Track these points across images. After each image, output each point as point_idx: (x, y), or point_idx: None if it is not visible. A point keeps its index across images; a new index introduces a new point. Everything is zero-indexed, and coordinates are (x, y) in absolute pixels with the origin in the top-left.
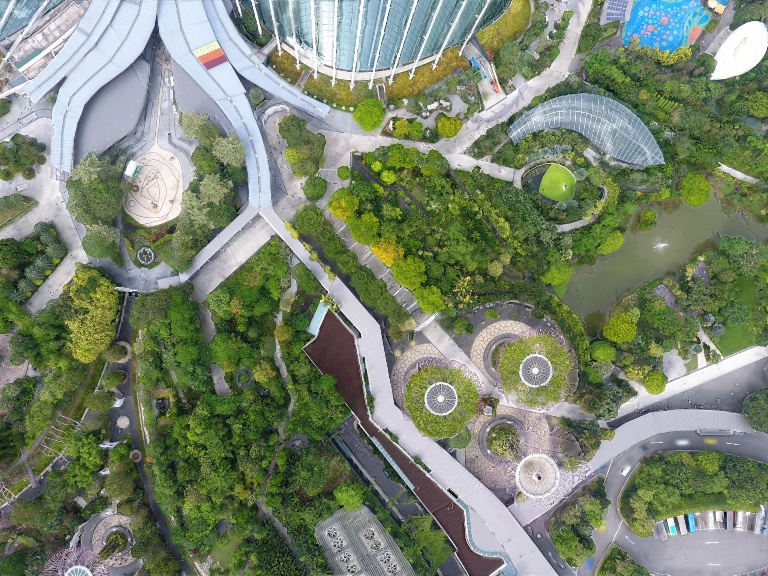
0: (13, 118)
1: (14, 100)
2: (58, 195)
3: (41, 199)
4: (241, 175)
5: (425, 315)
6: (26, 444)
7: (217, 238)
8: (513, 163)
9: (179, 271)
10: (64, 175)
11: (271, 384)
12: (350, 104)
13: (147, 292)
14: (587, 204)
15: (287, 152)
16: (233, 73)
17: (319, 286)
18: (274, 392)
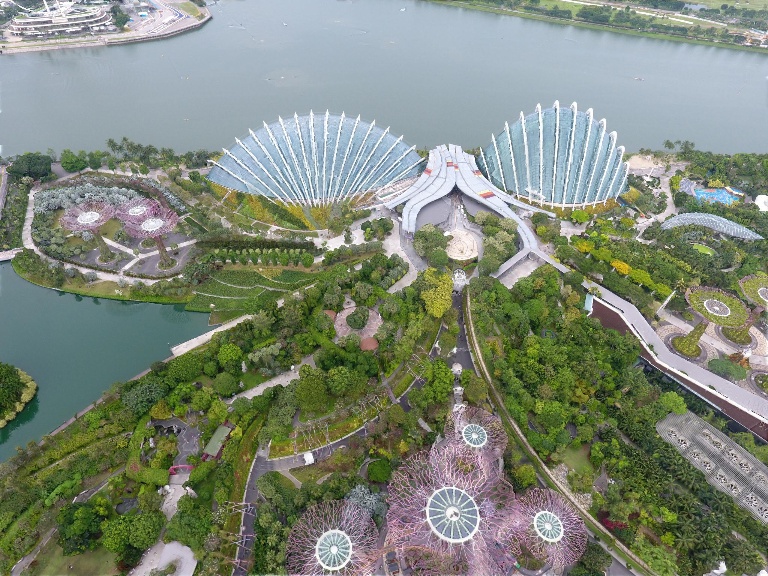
0: (372, 218)
1: (373, 212)
2: (399, 248)
3: (388, 249)
4: (516, 235)
5: (659, 310)
6: (389, 371)
7: (509, 260)
8: (672, 239)
9: (492, 271)
10: (409, 235)
11: (578, 325)
12: (563, 217)
13: (469, 285)
14: (732, 252)
15: (539, 228)
16: (500, 200)
17: (582, 287)
18: (581, 332)
